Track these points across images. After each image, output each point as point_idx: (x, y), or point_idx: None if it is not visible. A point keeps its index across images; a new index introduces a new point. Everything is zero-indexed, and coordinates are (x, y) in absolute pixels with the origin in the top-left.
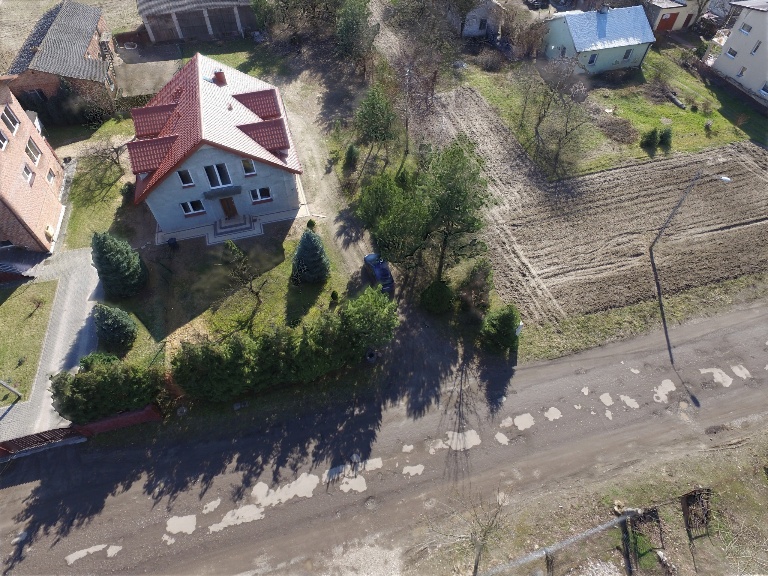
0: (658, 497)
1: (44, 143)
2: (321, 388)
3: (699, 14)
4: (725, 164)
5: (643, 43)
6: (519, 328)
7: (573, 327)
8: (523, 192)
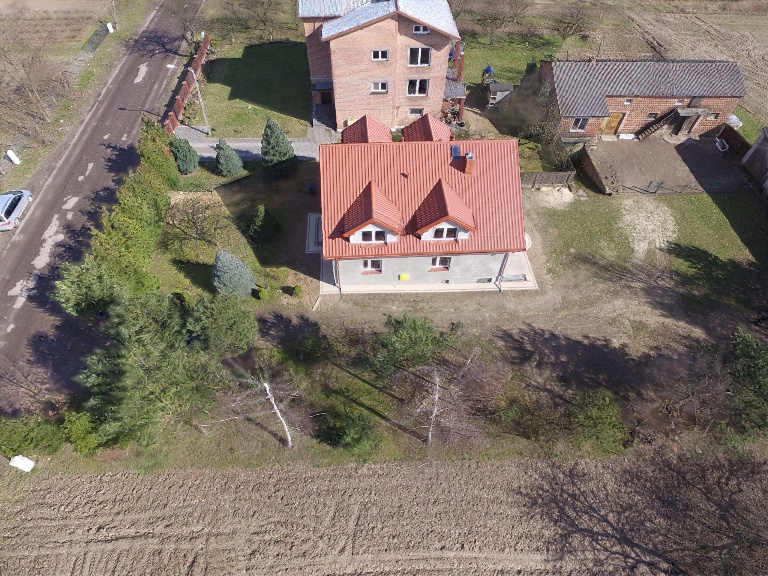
0: None
1: (442, 94)
2: None
3: None
4: None
5: None
6: None
7: None
8: None
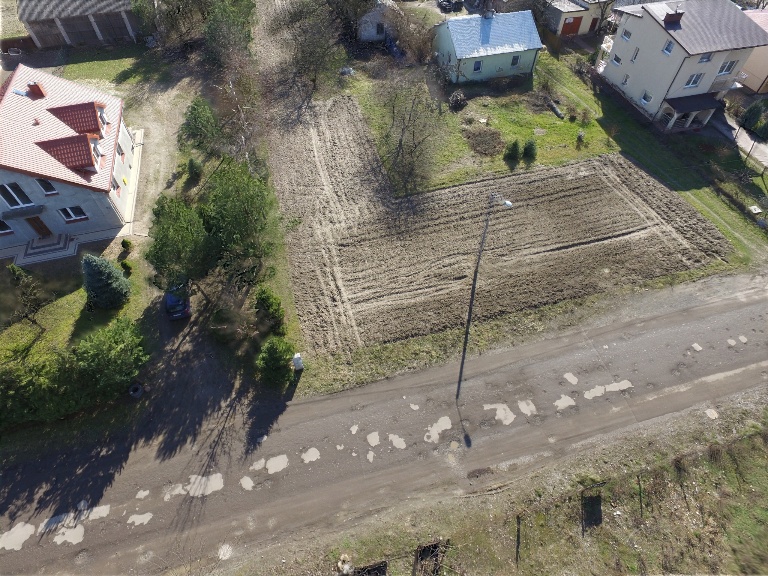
0: (392, 550)
1: None
2: (73, 426)
3: (602, 18)
4: (585, 178)
5: (529, 49)
6: (297, 360)
7: (365, 358)
8: (364, 209)
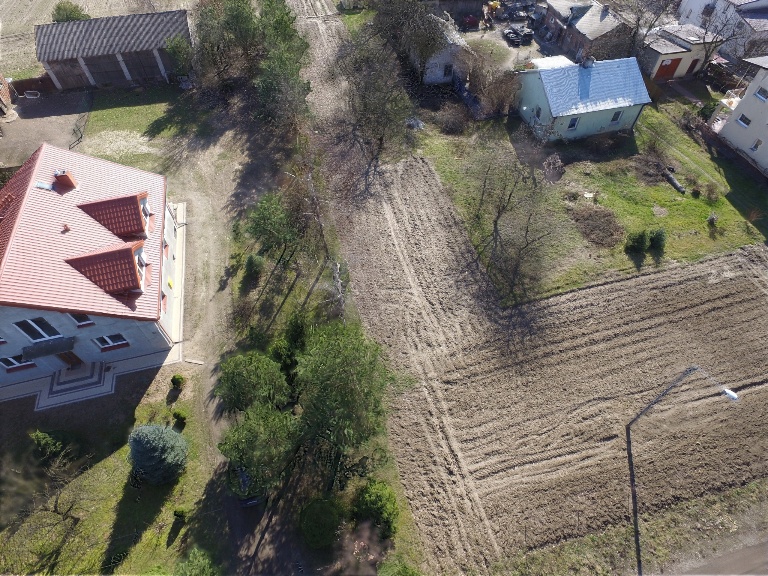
0: None
1: None
2: None
3: (706, 61)
4: (733, 281)
5: (635, 104)
6: None
7: None
8: (467, 324)
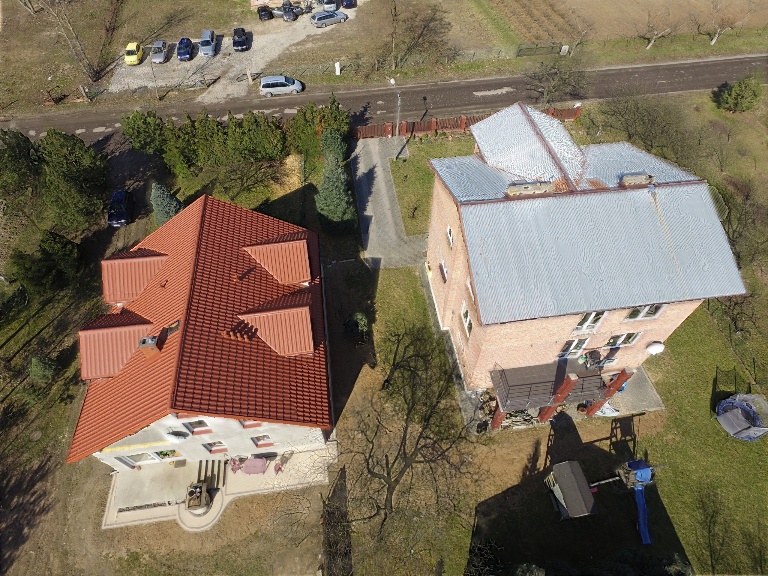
0: None
1: None
2: None
3: None
4: None
5: None
6: None
7: None
8: None
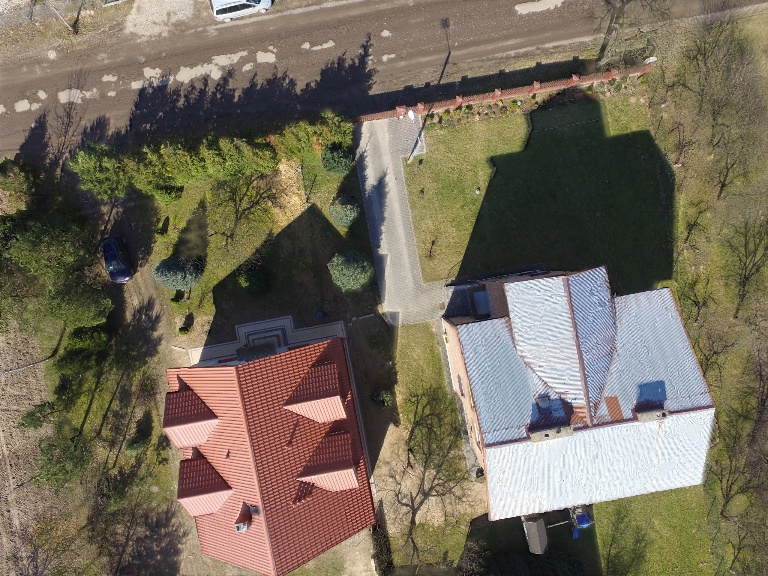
0: None
1: None
2: None
3: None
4: None
5: None
6: None
7: None
8: None
